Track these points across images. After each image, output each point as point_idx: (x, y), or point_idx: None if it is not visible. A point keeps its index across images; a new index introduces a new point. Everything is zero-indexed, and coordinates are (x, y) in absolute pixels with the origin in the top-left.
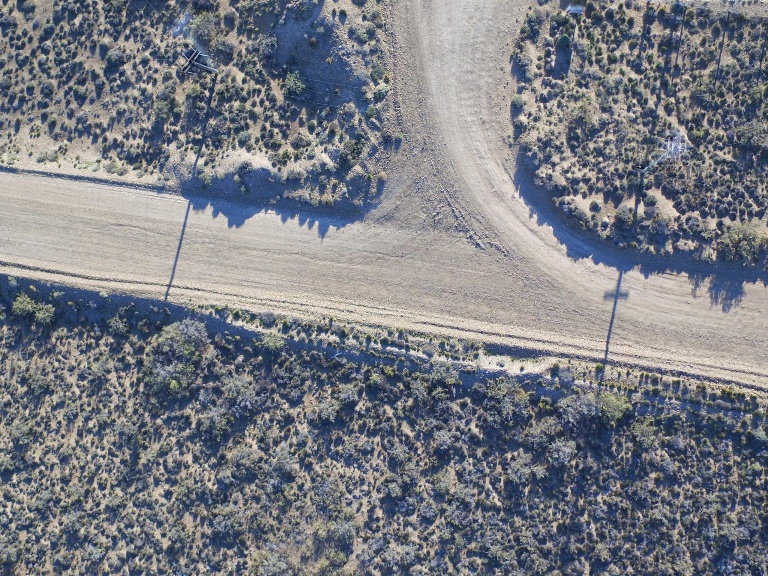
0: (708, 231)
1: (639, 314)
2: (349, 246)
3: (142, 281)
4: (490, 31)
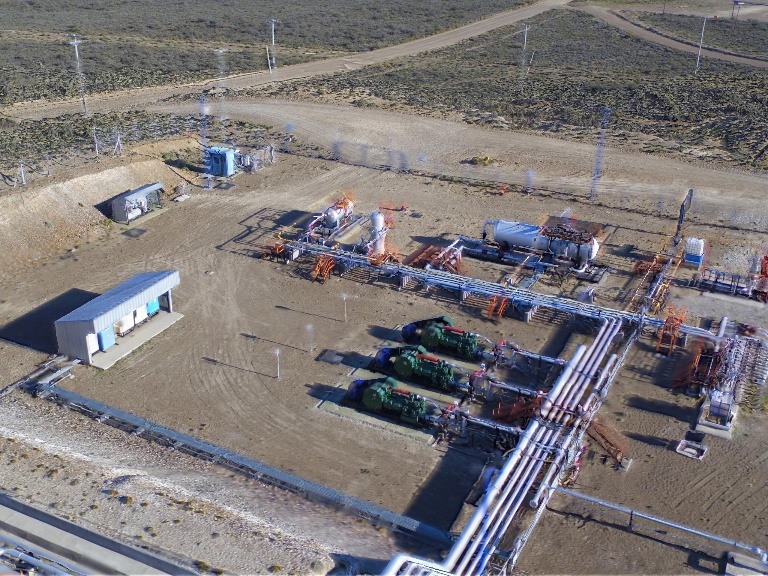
0: (26, 124)
1: None
2: None
3: None
4: None
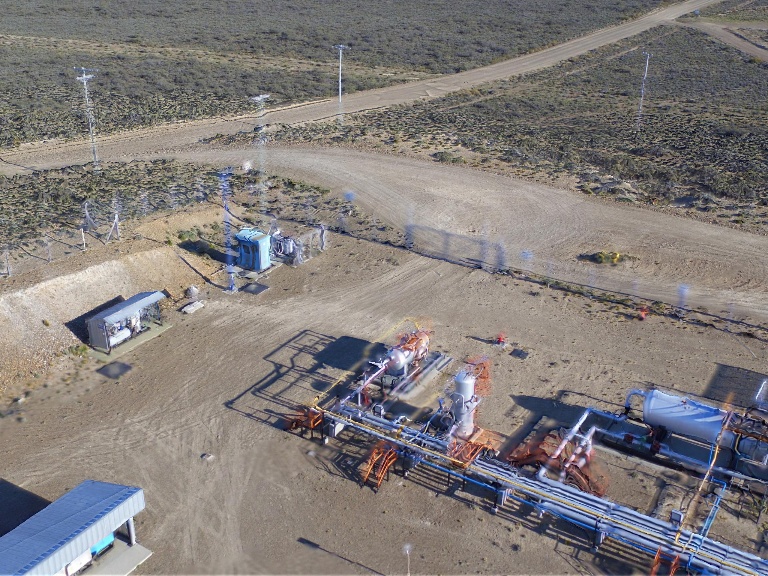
0: (19, 179)
1: (4, 169)
2: (185, 141)
3: (239, 120)
4: (270, 165)
